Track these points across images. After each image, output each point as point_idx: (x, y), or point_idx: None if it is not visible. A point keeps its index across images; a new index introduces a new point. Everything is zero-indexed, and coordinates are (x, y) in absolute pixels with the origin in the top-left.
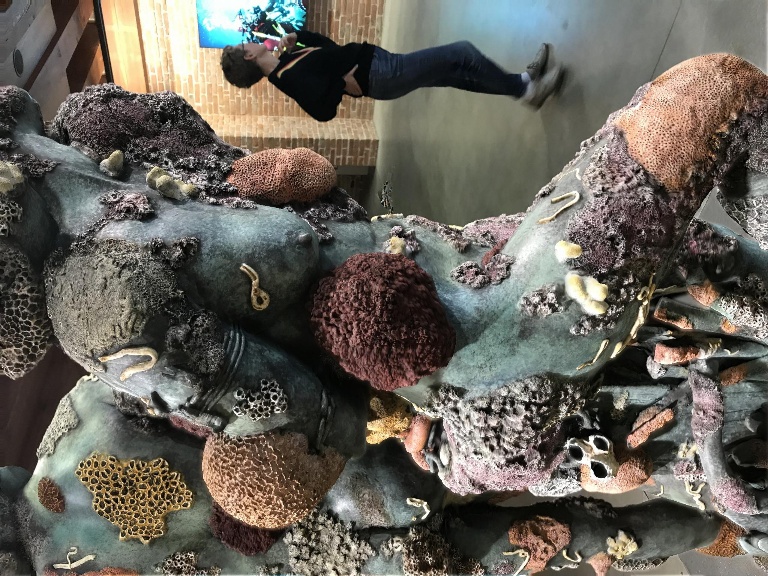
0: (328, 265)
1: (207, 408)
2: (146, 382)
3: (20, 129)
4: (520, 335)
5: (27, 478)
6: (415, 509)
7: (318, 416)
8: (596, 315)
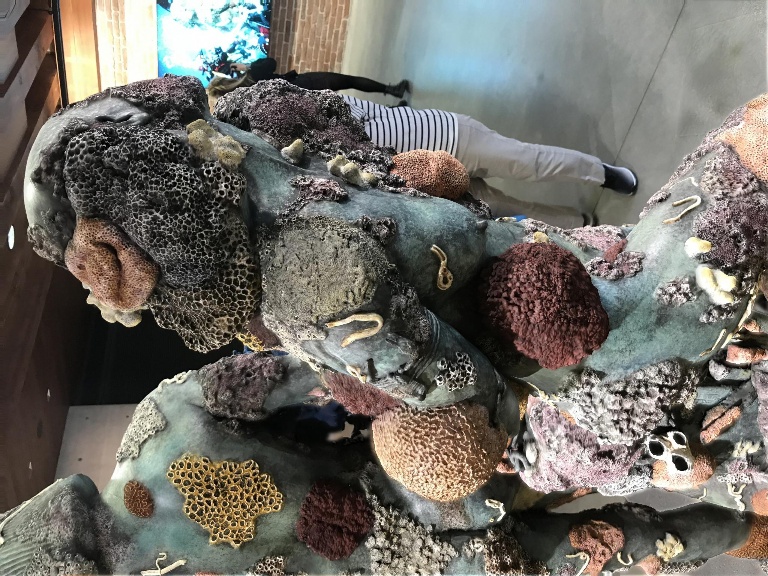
0: (485, 254)
1: (416, 376)
2: (365, 349)
3: (208, 114)
4: (657, 322)
5: (94, 487)
6: (493, 510)
7: (495, 391)
8: (722, 305)
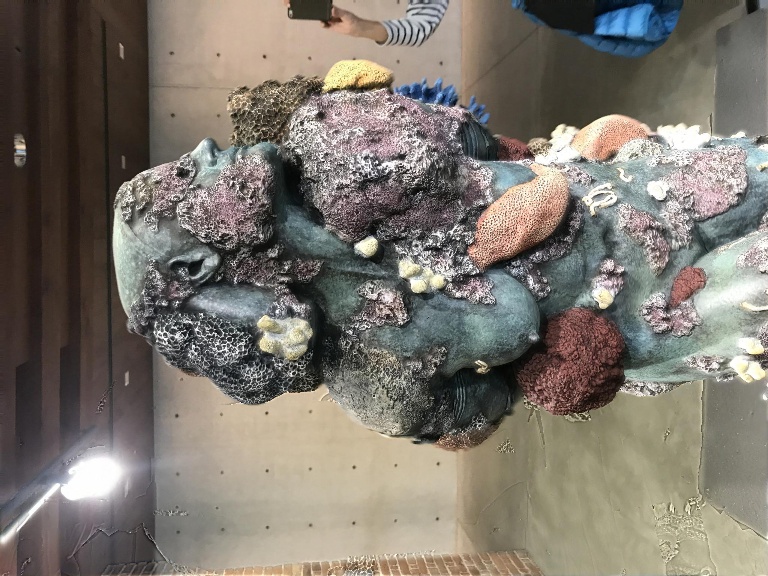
0: None
1: None
2: None
3: (279, 219)
4: (674, 373)
5: None
6: None
7: (502, 413)
8: None
